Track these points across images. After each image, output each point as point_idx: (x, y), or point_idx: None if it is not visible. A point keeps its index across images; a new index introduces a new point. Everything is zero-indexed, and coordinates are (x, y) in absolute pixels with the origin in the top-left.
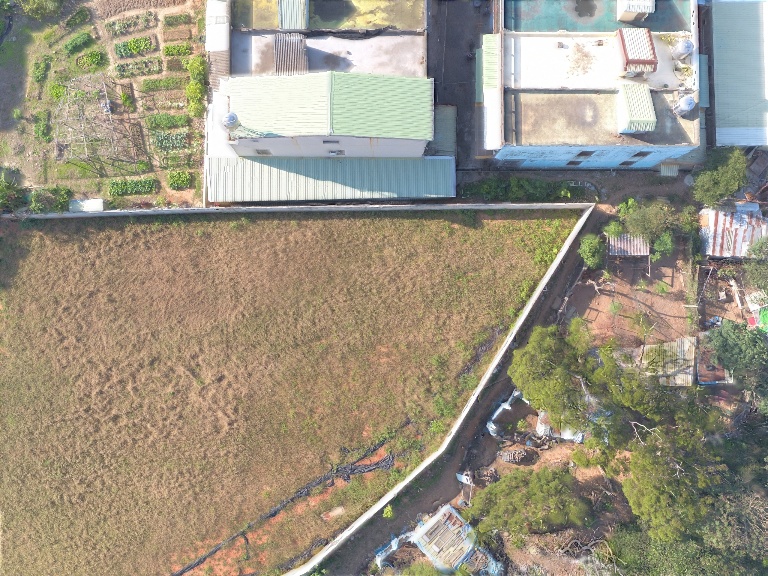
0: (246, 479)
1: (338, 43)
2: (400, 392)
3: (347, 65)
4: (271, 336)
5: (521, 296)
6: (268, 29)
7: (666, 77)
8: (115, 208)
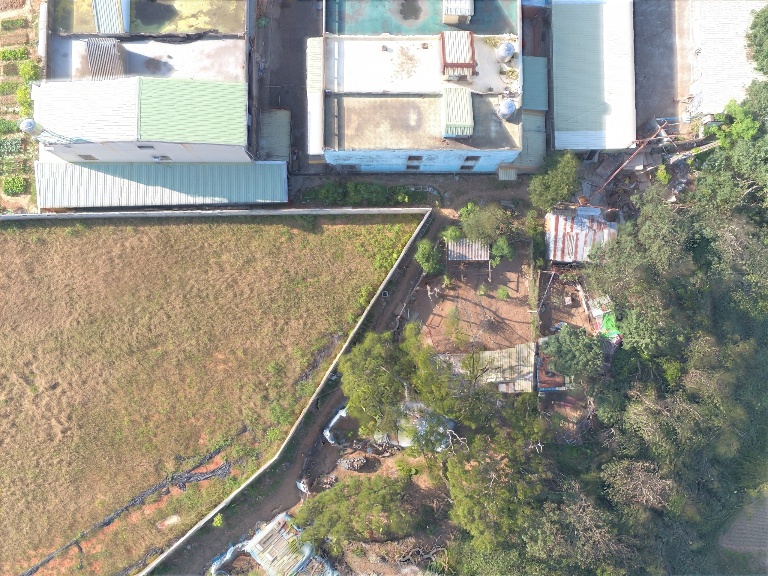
0: (80, 487)
1: (159, 47)
2: (236, 399)
3: (168, 70)
4: (106, 343)
5: (360, 302)
6: (87, 34)
7: (492, 80)
8: None
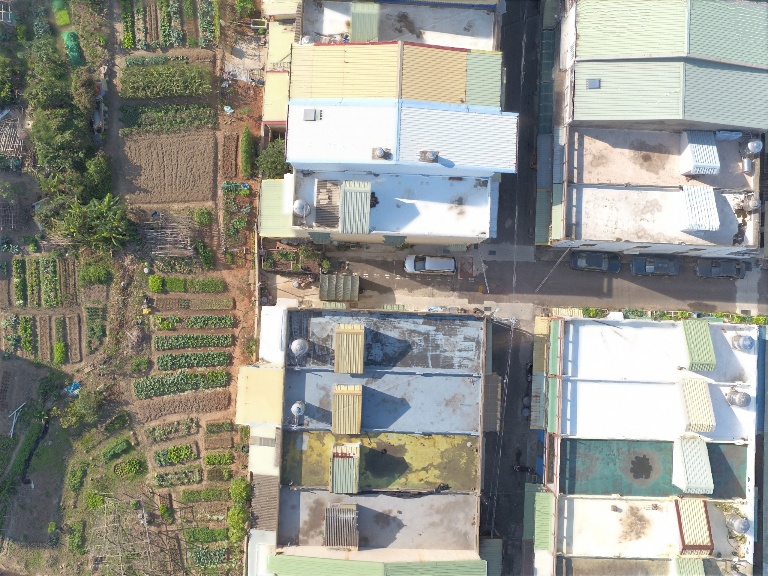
0: None
1: (388, 501)
2: None
3: (397, 524)
4: None
5: None
6: (317, 488)
7: (719, 544)
8: None
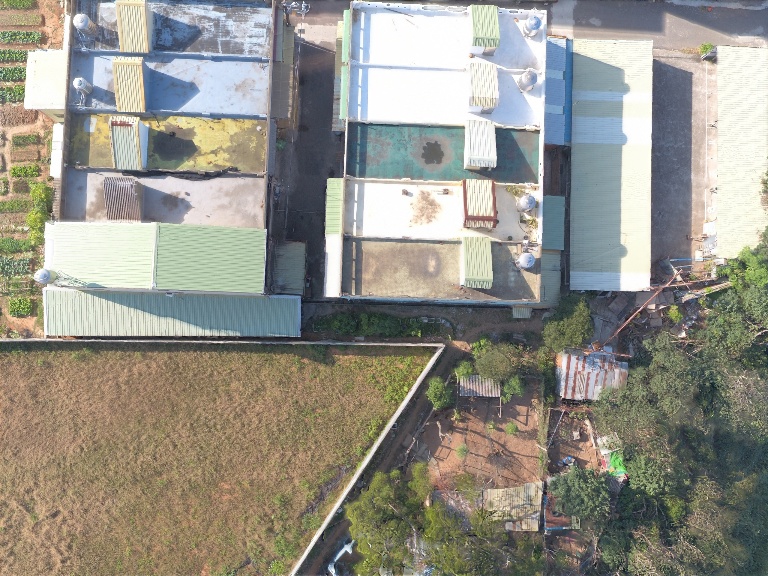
0: None
1: (176, 183)
2: (241, 531)
3: (185, 206)
4: (110, 471)
5: (369, 435)
6: (103, 167)
7: (511, 228)
8: None
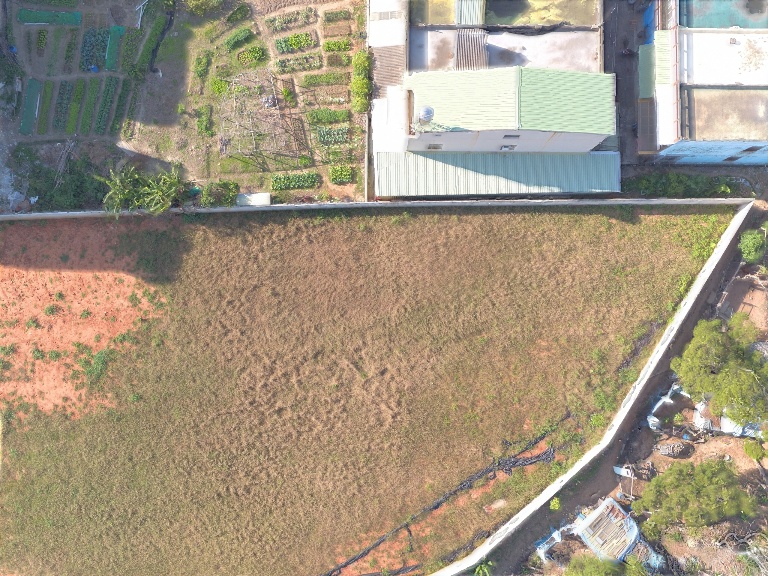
0: (409, 472)
1: (513, 39)
2: (561, 385)
3: (522, 60)
4: (433, 329)
5: (680, 290)
6: (445, 24)
7: None
8: (280, 202)
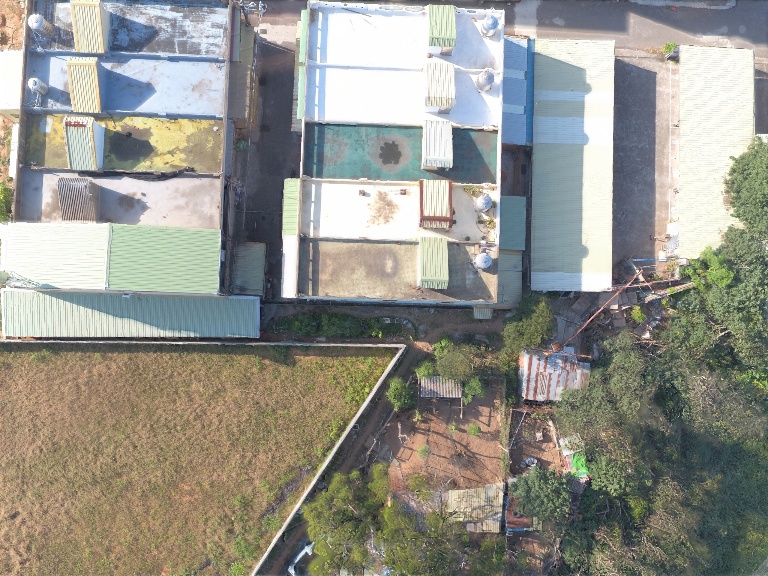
0: None
1: (133, 184)
2: (201, 533)
3: (141, 207)
4: (69, 472)
5: (330, 436)
6: (59, 168)
7: (469, 229)
8: None
